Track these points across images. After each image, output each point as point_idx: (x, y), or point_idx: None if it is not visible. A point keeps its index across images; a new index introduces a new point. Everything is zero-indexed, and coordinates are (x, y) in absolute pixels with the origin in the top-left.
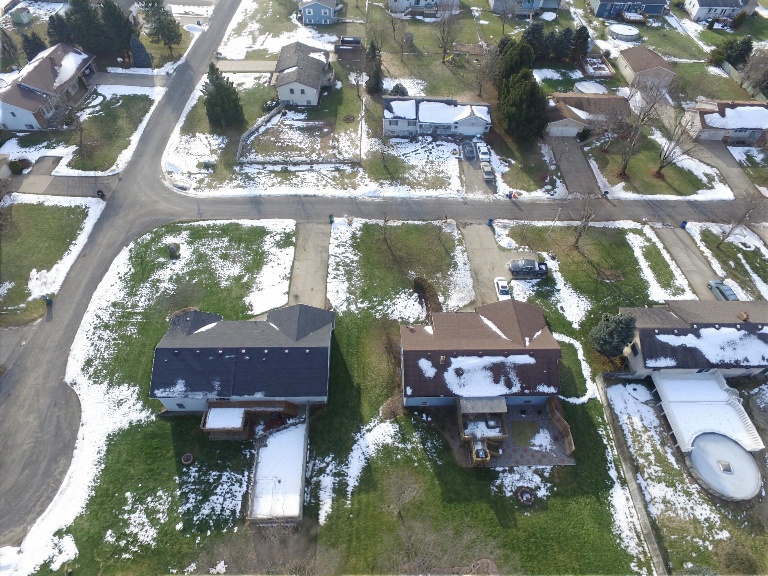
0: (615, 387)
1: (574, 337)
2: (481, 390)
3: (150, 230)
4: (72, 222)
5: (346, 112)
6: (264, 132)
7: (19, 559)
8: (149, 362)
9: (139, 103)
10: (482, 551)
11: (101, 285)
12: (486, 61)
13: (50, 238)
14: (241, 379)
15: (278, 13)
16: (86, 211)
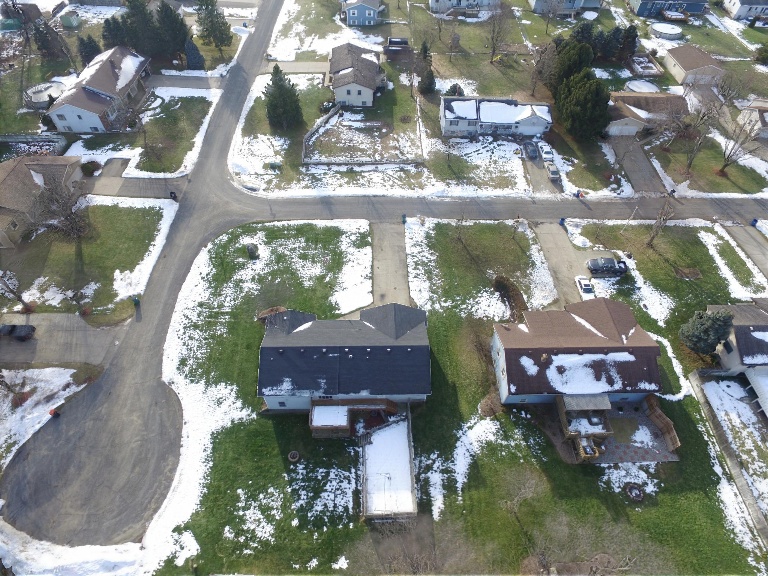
0: (709, 384)
1: (661, 335)
2: (584, 387)
3: (226, 231)
4: (148, 223)
5: (402, 113)
6: (324, 133)
7: (143, 555)
8: (243, 361)
9: (197, 105)
10: (599, 546)
11: (185, 285)
12: (543, 61)
13: (129, 239)
14: (346, 377)
15: (321, 14)
16: (160, 212)
